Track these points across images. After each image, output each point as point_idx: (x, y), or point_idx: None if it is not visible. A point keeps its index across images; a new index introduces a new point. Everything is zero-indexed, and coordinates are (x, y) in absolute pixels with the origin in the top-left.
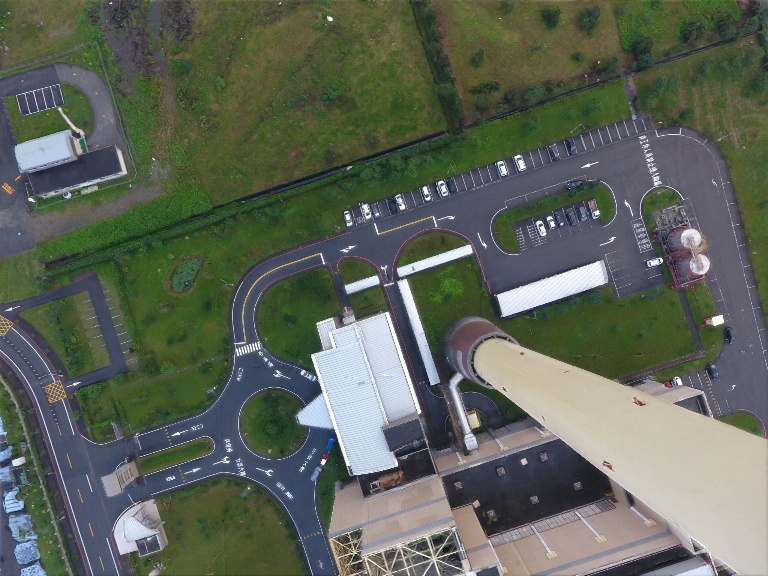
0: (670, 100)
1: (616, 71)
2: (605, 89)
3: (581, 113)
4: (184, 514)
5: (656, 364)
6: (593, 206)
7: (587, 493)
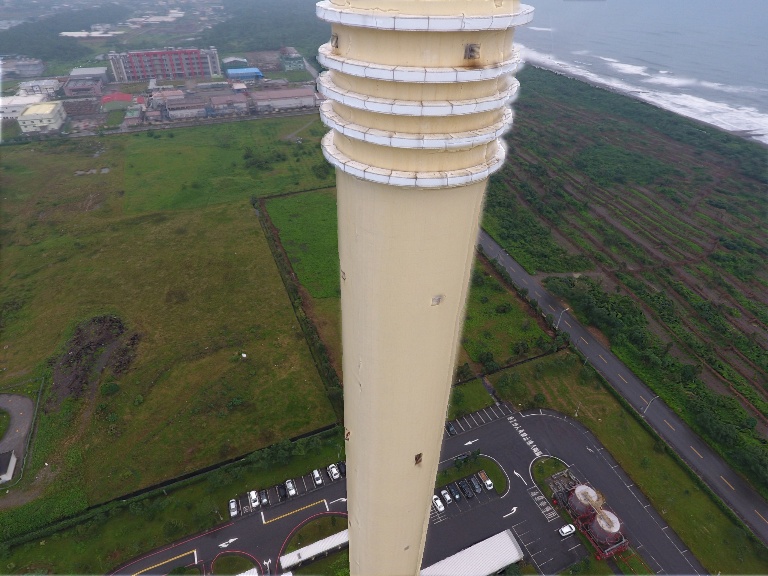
0: (520, 388)
1: (472, 374)
2: (467, 386)
3: (452, 403)
4: None
5: None
6: (484, 477)
7: None
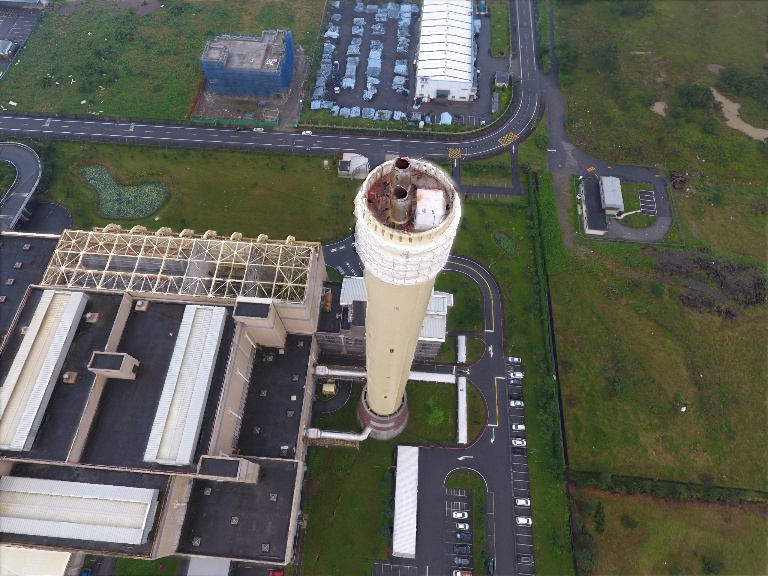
0: None
1: None
2: None
3: None
4: (351, 191)
5: (302, 572)
6: (466, 575)
7: (247, 436)
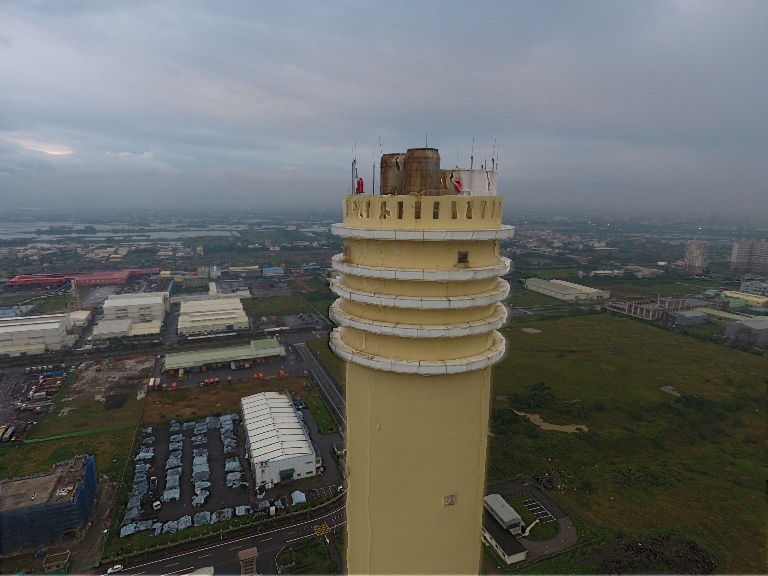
0: None
1: None
2: None
3: None
4: None
5: None
6: None
7: None
